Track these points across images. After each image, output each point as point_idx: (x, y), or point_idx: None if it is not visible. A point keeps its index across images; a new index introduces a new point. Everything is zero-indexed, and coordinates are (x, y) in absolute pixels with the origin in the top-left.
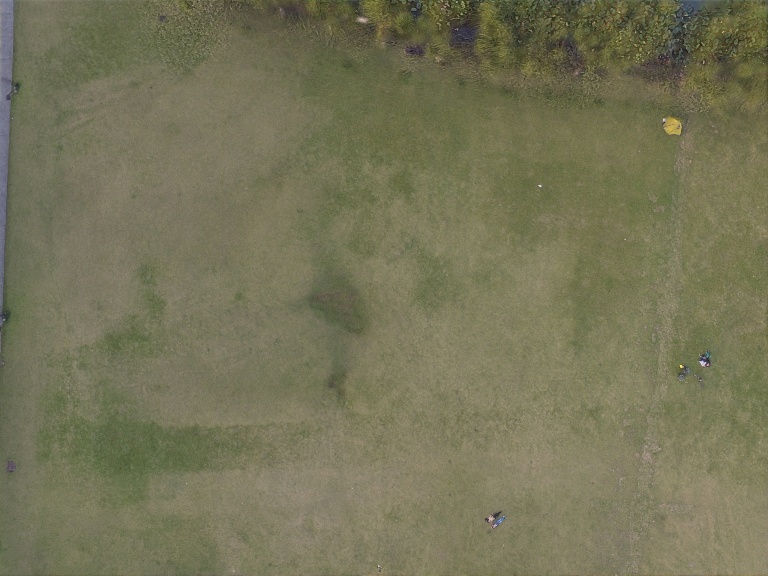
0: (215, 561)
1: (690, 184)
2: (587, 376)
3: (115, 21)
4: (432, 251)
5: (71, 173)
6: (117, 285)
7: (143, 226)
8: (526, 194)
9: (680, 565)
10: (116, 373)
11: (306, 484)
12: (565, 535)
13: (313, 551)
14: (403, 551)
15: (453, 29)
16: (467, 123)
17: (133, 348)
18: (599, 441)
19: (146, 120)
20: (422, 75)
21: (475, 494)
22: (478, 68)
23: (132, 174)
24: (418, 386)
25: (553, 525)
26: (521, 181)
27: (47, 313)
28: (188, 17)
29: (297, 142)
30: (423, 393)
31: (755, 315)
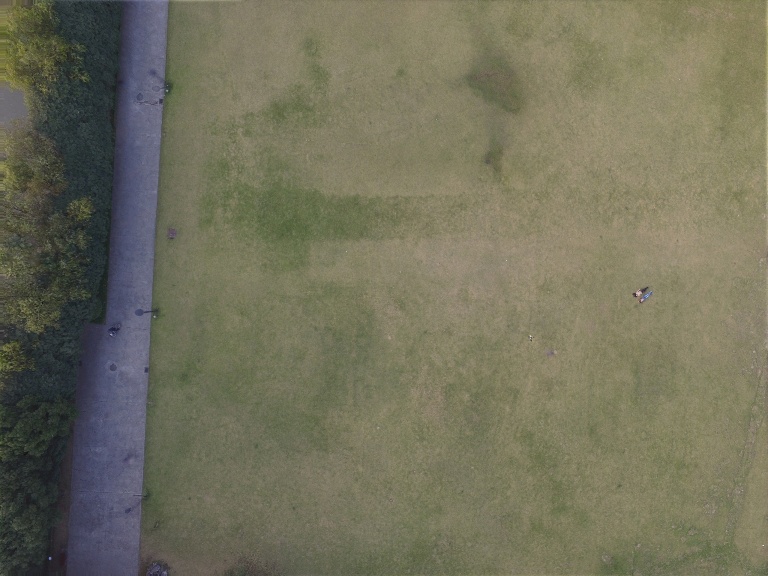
0: (371, 328)
1: None
2: (733, 160)
3: None
4: (588, 36)
5: None
6: (283, 56)
7: (308, 1)
8: None
9: None
10: (281, 141)
11: (462, 255)
12: (707, 312)
13: (467, 320)
14: (554, 322)
15: None
16: None
17: (297, 118)
18: (742, 223)
19: None
20: None
21: (624, 269)
22: None
23: None
24: (573, 163)
25: (696, 302)
26: None
27: (212, 82)
28: None
29: None
30: (578, 170)
31: None
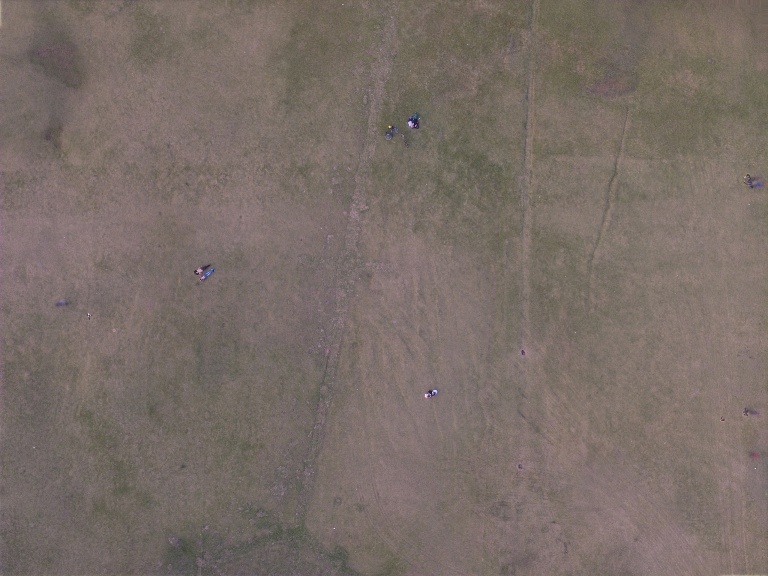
0: None
1: None
2: (298, 134)
3: None
4: (151, 9)
5: None
6: None
7: None
8: None
9: (384, 321)
10: None
11: (19, 232)
12: (273, 290)
13: (25, 298)
14: (112, 300)
15: None
16: None
17: None
18: (308, 199)
19: None
20: None
21: (184, 246)
22: None
23: None
24: (130, 138)
25: (261, 280)
26: None
27: None
28: None
29: None
30: (135, 145)
31: (467, 82)
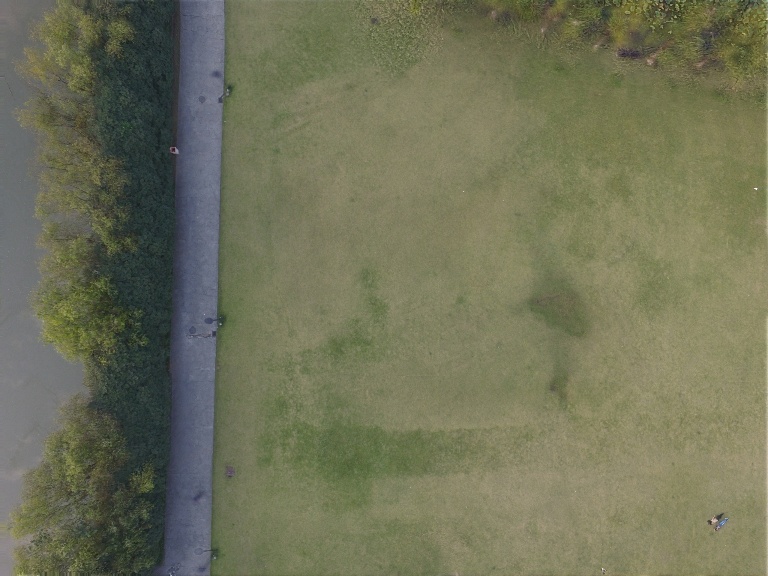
0: (438, 565)
1: None
2: None
3: (328, 23)
4: (652, 254)
5: (288, 176)
6: (339, 289)
7: (363, 230)
8: (742, 197)
9: None
10: (339, 377)
11: (530, 487)
12: None
13: (537, 554)
14: (627, 554)
15: (666, 32)
16: (681, 126)
17: (356, 352)
18: None
19: (362, 123)
20: (634, 78)
21: (698, 496)
22: (690, 71)
23: (350, 177)
24: (642, 389)
25: None
26: (737, 184)
27: (267, 317)
28: (399, 19)
29: (513, 145)
30: (647, 396)
31: None
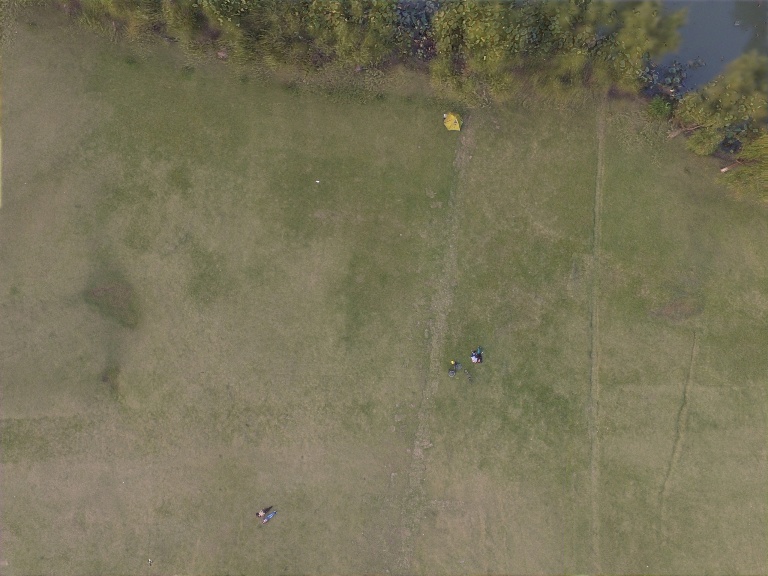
0: None
1: (469, 180)
2: (359, 371)
3: None
4: (206, 246)
5: None
6: None
7: None
8: (303, 189)
9: (451, 561)
10: None
11: (78, 478)
12: (336, 530)
13: (85, 544)
14: (174, 545)
15: (234, 25)
16: (248, 119)
17: None
18: (371, 437)
19: None
20: (205, 71)
21: (246, 489)
22: (260, 64)
23: None
24: (188, 381)
25: (324, 520)
26: (299, 176)
27: None
28: None
29: (77, 137)
30: (193, 388)
31: (530, 311)
